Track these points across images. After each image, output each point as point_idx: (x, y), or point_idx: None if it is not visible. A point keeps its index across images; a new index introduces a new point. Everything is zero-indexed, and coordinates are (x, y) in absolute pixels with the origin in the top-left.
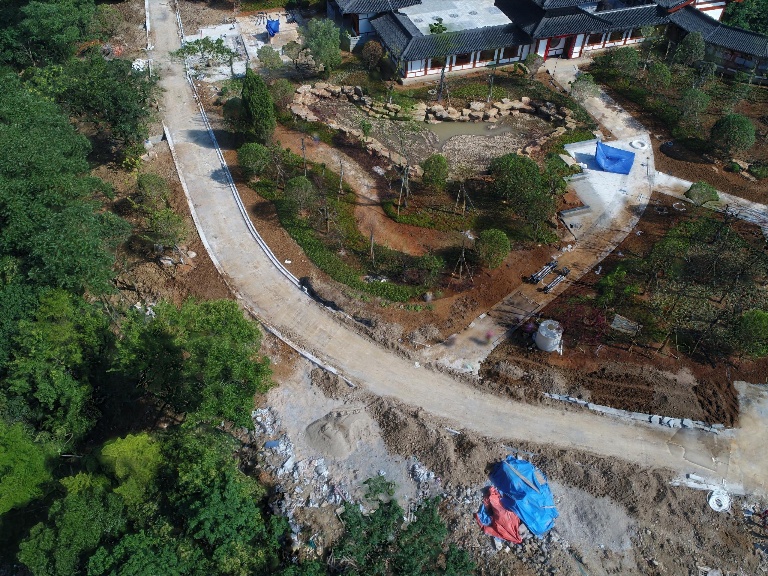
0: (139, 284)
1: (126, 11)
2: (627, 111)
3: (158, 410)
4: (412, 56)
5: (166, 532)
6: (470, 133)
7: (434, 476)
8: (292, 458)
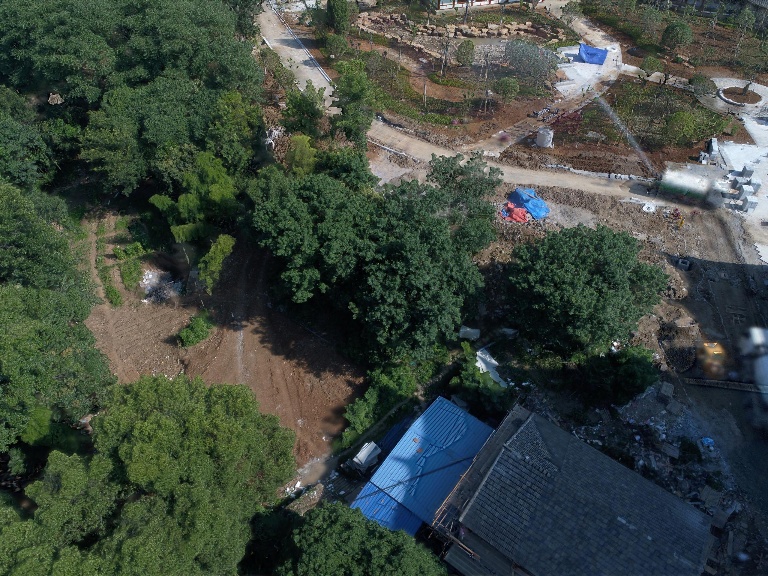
0: (264, 119)
1: None
2: (604, 31)
3: None
4: None
5: None
6: (488, 44)
7: None
8: None
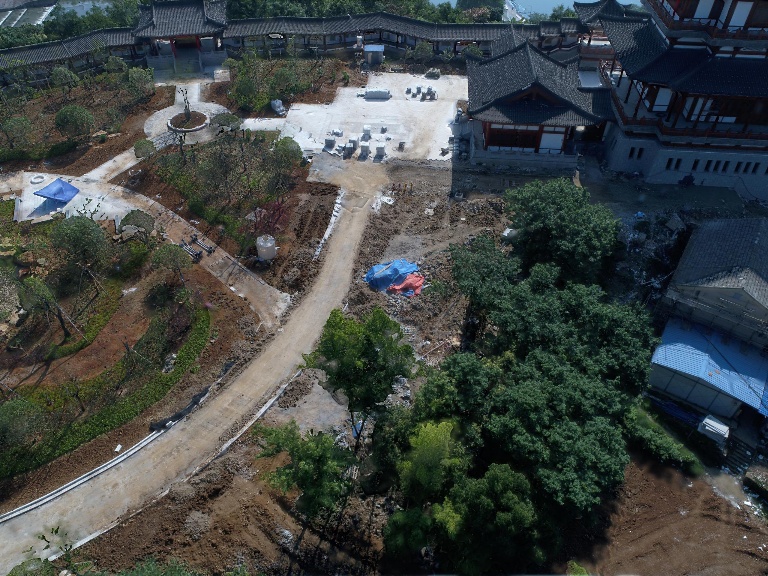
0: None
1: None
2: None
3: (304, 573)
4: None
5: None
6: None
7: None
8: None
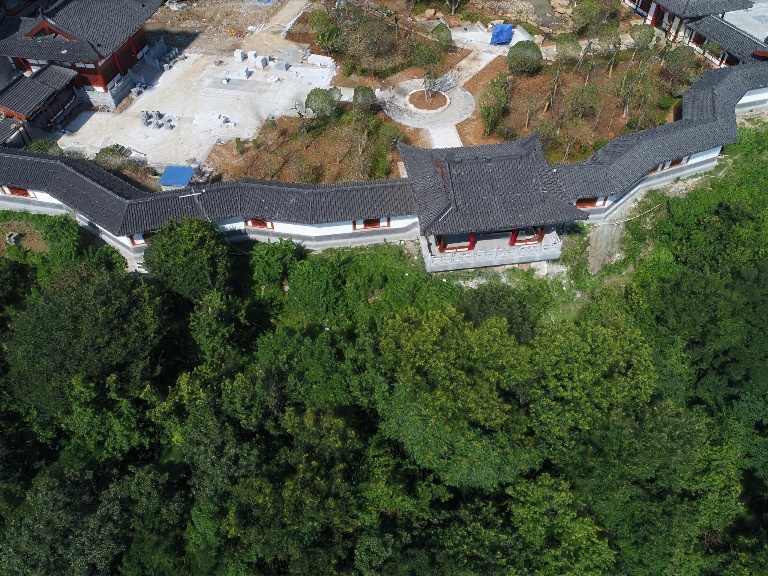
0: None
1: None
2: None
3: None
4: None
5: None
6: (537, 8)
7: None
8: None
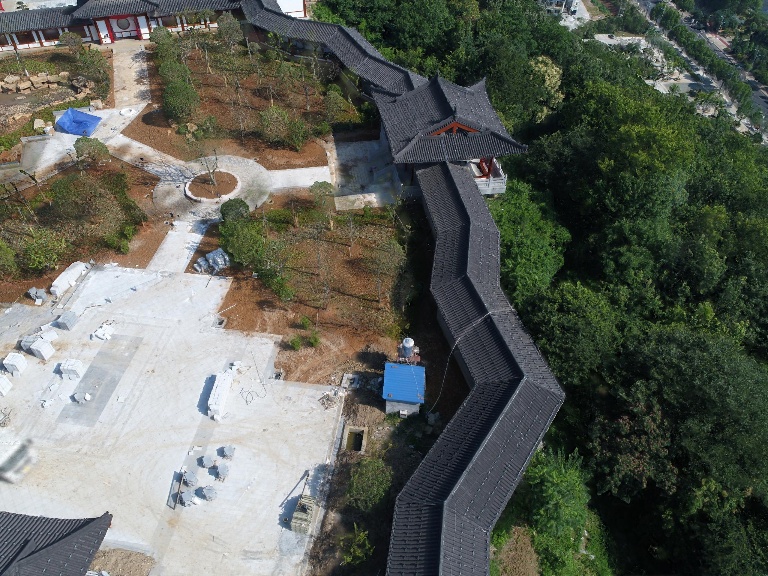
0: None
1: None
2: (149, 84)
3: None
4: None
5: None
6: None
7: None
8: None
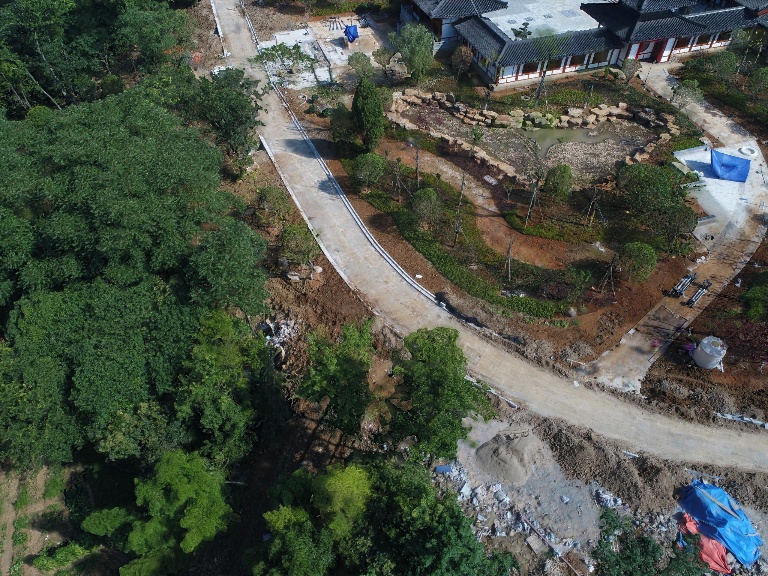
0: (267, 300)
1: (194, 17)
2: (728, 116)
3: (309, 433)
4: (507, 62)
5: (389, 570)
6: (571, 140)
7: (621, 502)
8: (468, 484)
